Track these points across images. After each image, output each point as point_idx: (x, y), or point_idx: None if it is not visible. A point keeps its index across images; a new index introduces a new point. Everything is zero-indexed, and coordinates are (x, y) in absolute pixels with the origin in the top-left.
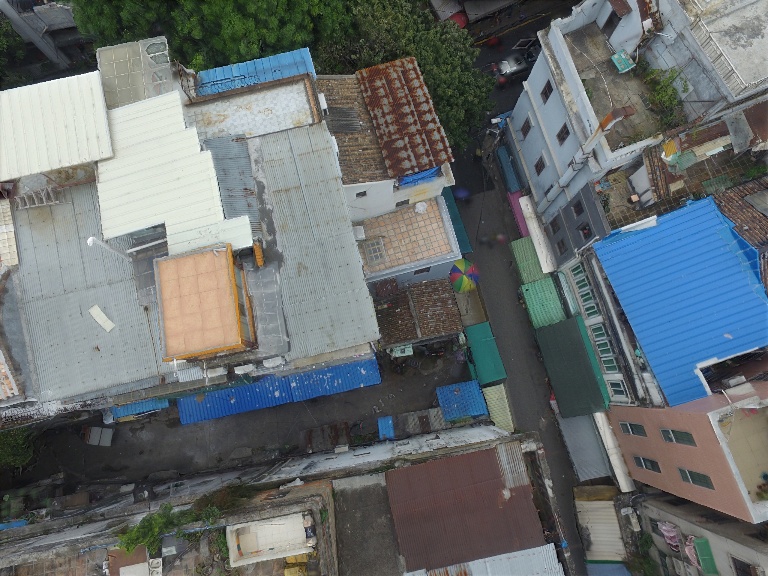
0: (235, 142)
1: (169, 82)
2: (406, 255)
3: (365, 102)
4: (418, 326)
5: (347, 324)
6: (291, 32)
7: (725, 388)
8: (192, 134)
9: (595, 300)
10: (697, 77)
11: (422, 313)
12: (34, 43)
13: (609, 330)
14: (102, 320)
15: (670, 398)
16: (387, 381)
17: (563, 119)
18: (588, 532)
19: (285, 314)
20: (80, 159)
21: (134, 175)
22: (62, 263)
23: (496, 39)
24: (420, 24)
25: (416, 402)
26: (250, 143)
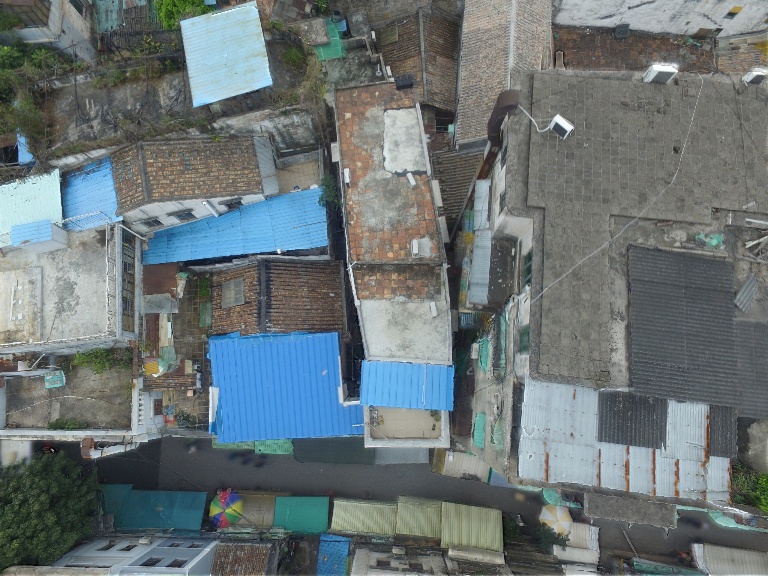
0: None
1: None
2: None
3: None
4: None
5: None
6: None
7: None
8: None
9: None
10: None
11: None
12: None
13: None
14: None
15: (360, 432)
16: None
17: None
18: (467, 475)
19: None
20: None
21: None
22: None
23: None
24: None
25: None
26: None
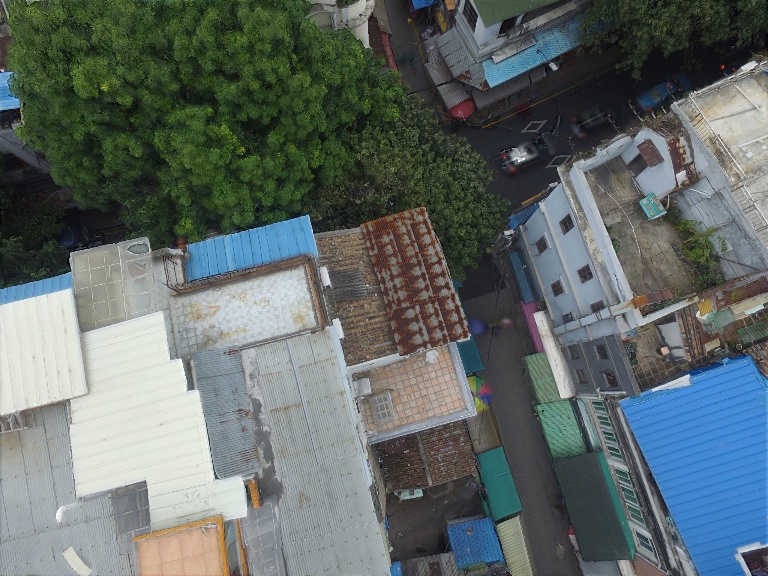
0: (227, 355)
1: (154, 266)
2: (416, 412)
3: (371, 261)
4: (428, 472)
5: (355, 565)
6: (289, 194)
7: (767, 570)
8: (177, 368)
9: (620, 446)
10: (737, 240)
11: (432, 456)
12: (14, 154)
13: (636, 486)
14: (77, 566)
15: None
16: (394, 506)
17: (586, 260)
18: None
19: (285, 554)
20: (49, 398)
21: (111, 416)
22: (32, 497)
23: (505, 121)
24: (429, 154)
25: (425, 529)
26: (244, 355)
